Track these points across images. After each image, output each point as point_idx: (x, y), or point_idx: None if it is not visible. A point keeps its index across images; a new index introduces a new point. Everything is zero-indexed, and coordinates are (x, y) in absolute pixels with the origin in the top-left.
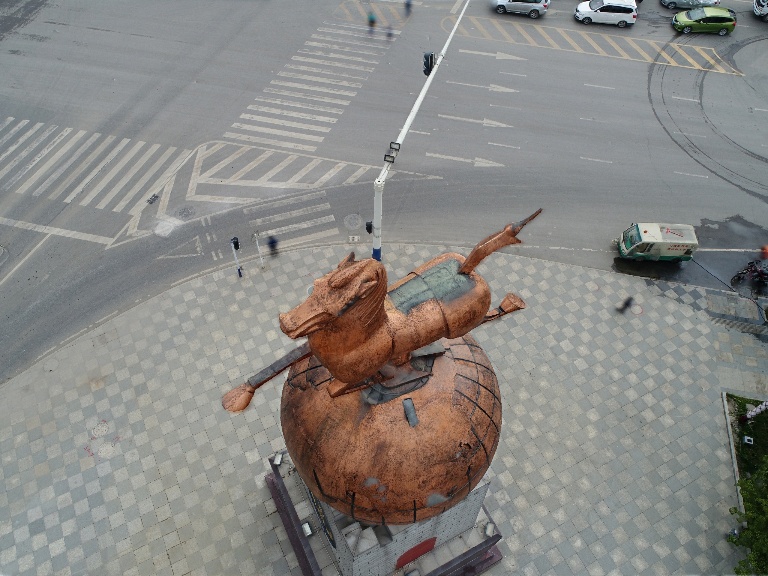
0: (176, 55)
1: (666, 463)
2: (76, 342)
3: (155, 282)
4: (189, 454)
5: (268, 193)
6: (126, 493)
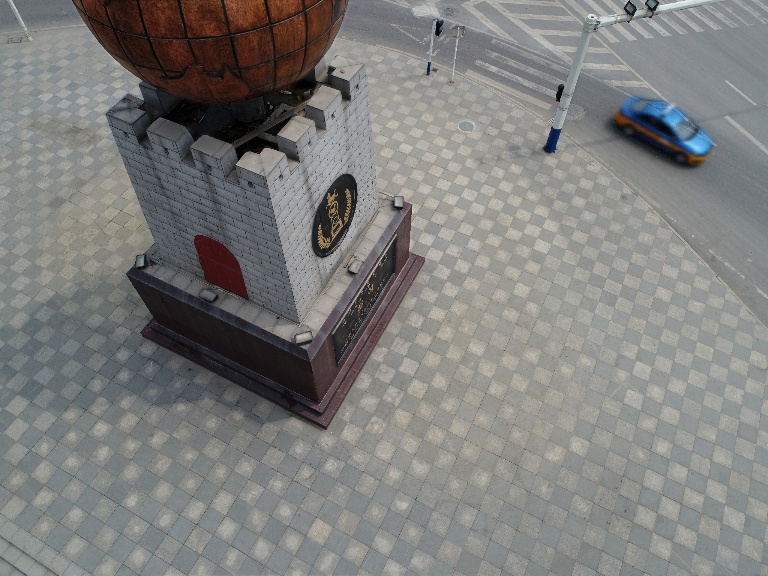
0: None
1: (598, 572)
2: None
3: (370, 36)
4: None
5: (529, 43)
6: None
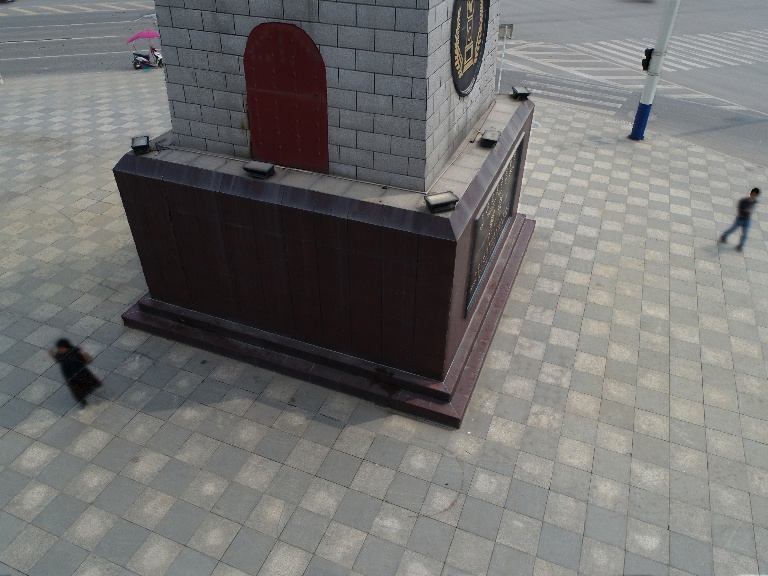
0: (580, 10)
1: None
2: None
3: None
4: None
5: (566, 75)
6: None
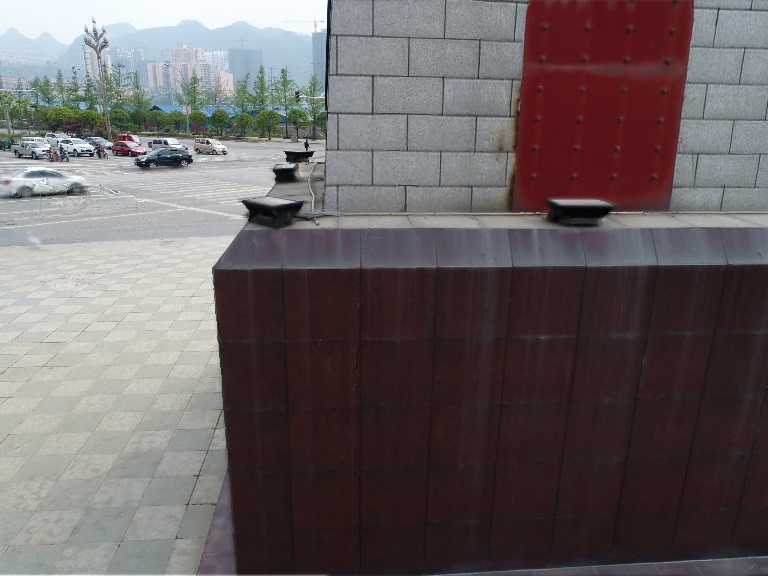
0: None
1: None
2: (135, 240)
3: None
4: (169, 305)
5: None
6: (37, 313)
